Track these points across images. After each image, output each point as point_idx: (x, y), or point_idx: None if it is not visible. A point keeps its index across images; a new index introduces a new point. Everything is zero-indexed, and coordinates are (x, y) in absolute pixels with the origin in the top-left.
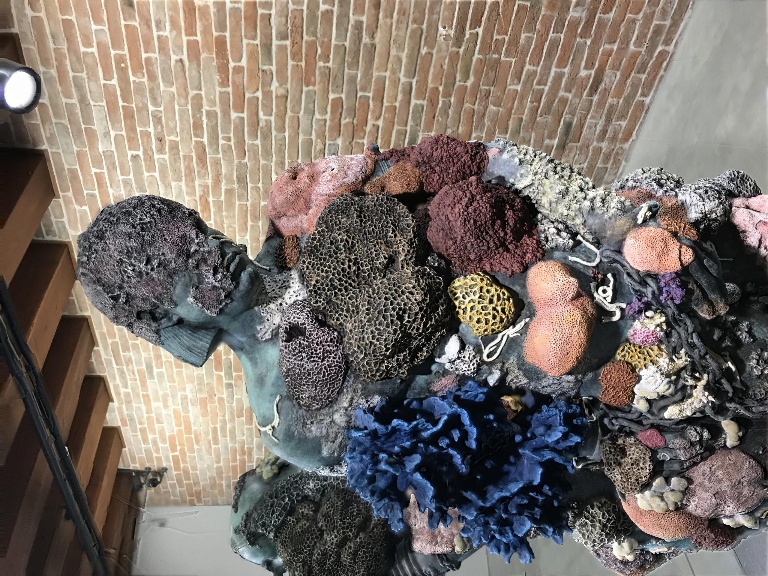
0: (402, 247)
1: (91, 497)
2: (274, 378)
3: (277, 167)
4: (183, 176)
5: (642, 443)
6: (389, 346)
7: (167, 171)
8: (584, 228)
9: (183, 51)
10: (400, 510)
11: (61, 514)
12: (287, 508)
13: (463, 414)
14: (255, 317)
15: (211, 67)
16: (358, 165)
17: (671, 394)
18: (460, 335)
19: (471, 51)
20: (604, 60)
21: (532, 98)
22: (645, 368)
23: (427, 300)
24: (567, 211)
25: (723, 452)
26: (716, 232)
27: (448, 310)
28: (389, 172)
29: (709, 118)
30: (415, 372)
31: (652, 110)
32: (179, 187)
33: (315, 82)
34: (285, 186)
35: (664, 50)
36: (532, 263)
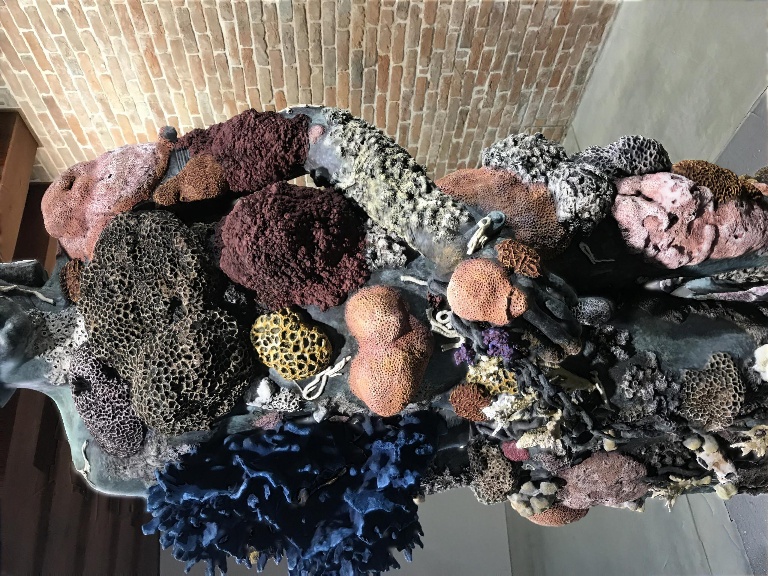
0: (183, 292)
1: None
2: (79, 422)
3: (223, 10)
4: (120, 29)
5: (504, 456)
6: (169, 417)
7: (101, 25)
8: (414, 247)
9: None
10: (211, 569)
11: None
12: None
13: None
14: (39, 366)
15: None
16: (143, 166)
17: (528, 419)
18: (271, 378)
19: None
20: None
21: None
22: (500, 390)
23: (209, 363)
24: (393, 225)
25: (599, 455)
26: (589, 234)
27: (248, 359)
28: (184, 171)
29: None
30: (228, 415)
31: None
32: (119, 42)
33: None
34: (53, 203)
35: None
36: (352, 291)
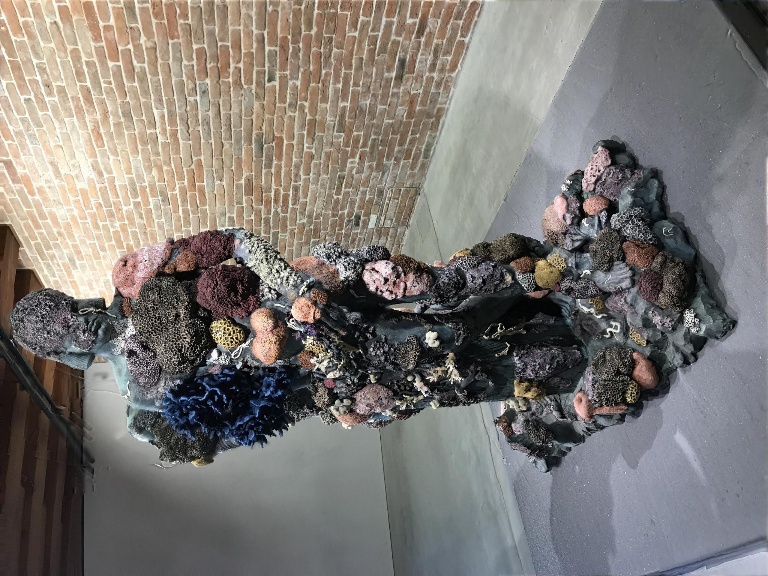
0: (181, 311)
1: (38, 369)
2: (125, 372)
3: (156, 103)
4: (74, 114)
5: (325, 386)
6: (176, 364)
7: (59, 110)
8: None
9: (56, 15)
10: (190, 434)
11: (16, 387)
12: (156, 414)
13: (217, 390)
14: (110, 345)
15: (83, 27)
16: (160, 256)
17: (332, 366)
18: (218, 348)
19: (311, 7)
20: (426, 11)
21: (369, 42)
22: None
23: (194, 340)
24: (270, 283)
25: (370, 385)
26: (353, 286)
27: (208, 340)
28: (178, 258)
29: (500, 72)
30: (197, 366)
31: (470, 49)
32: (72, 123)
33: (179, 36)
34: (119, 273)
35: (475, 2)
36: (254, 310)
